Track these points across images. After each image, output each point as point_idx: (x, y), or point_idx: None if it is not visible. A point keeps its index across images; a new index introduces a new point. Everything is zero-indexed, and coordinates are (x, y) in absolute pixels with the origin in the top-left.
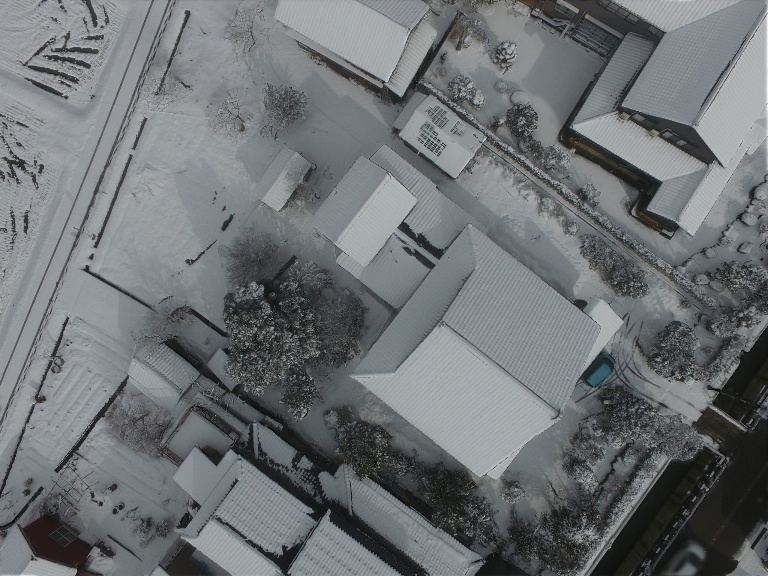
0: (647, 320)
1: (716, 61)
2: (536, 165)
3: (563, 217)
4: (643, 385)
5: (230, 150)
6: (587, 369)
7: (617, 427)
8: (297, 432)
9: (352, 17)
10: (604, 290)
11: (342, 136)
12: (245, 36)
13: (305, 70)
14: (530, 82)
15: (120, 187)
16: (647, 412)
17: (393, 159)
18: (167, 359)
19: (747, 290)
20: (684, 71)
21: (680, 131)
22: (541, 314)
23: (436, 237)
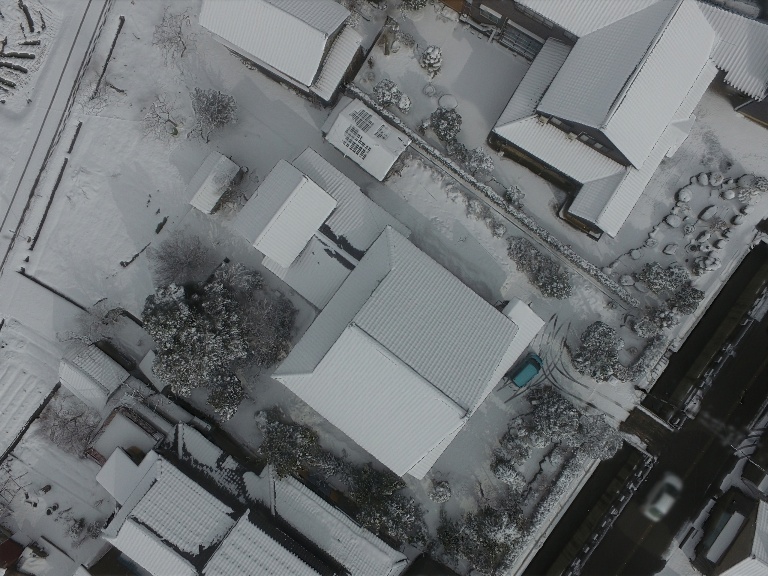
0: (574, 321)
1: (624, 65)
2: (462, 168)
3: (490, 219)
4: (571, 385)
5: (163, 153)
6: (515, 369)
7: (539, 427)
8: (229, 433)
9: (272, 23)
10: (532, 291)
11: (274, 139)
12: (174, 41)
13: (237, 75)
14: (459, 86)
15: (56, 190)
16: (566, 412)
17: (317, 162)
18: (96, 360)
19: (669, 291)
20: (594, 75)
21: (594, 134)
22: (456, 315)
23: (357, 239)
